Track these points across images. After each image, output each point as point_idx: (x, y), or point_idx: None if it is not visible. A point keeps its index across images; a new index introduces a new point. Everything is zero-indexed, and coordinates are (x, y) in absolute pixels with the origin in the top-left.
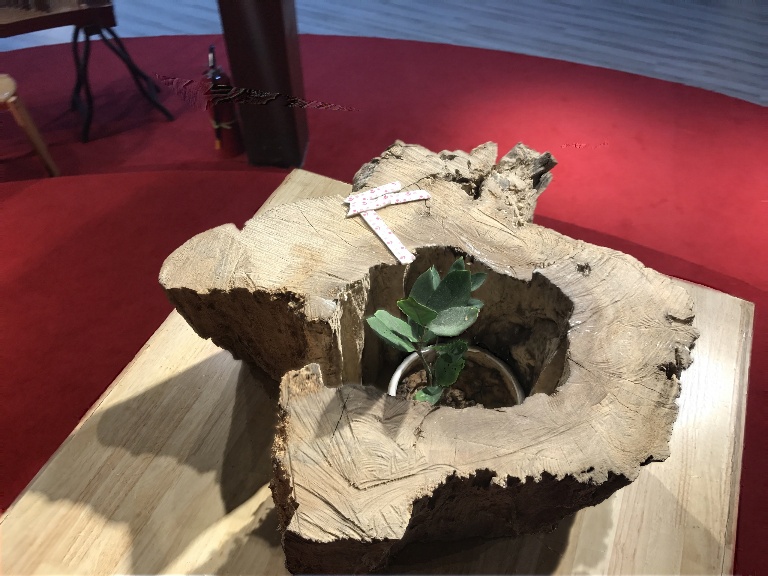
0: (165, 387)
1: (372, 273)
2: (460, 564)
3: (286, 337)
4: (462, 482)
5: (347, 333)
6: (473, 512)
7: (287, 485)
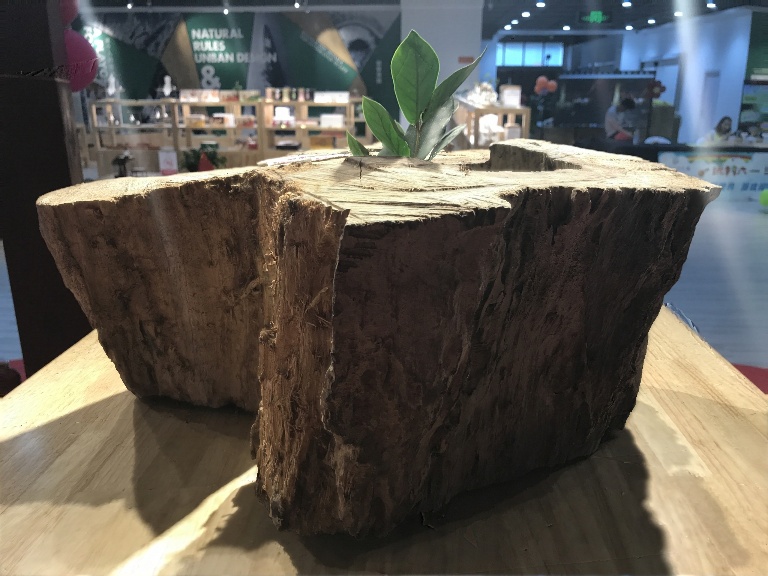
0: (15, 442)
1: None
2: (533, 500)
3: (219, 273)
4: (538, 207)
5: None
6: (532, 382)
7: (311, 245)
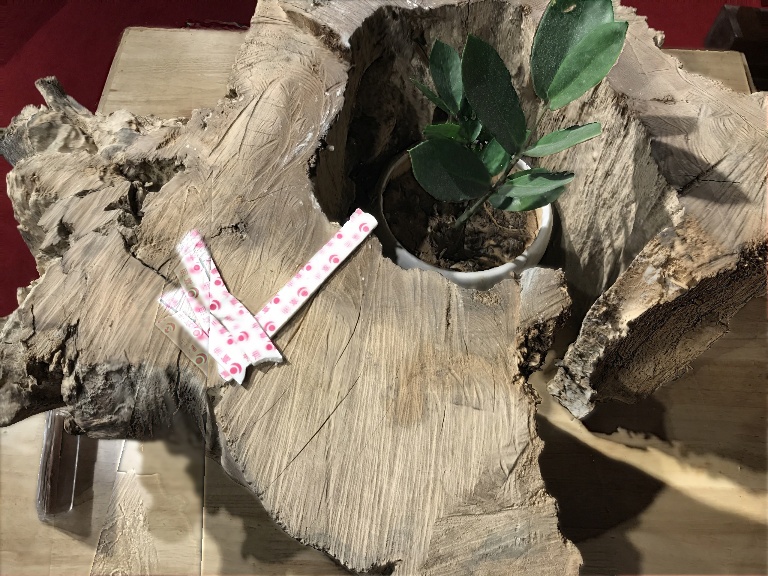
0: None
1: None
2: None
3: None
4: None
5: None
6: None
7: None
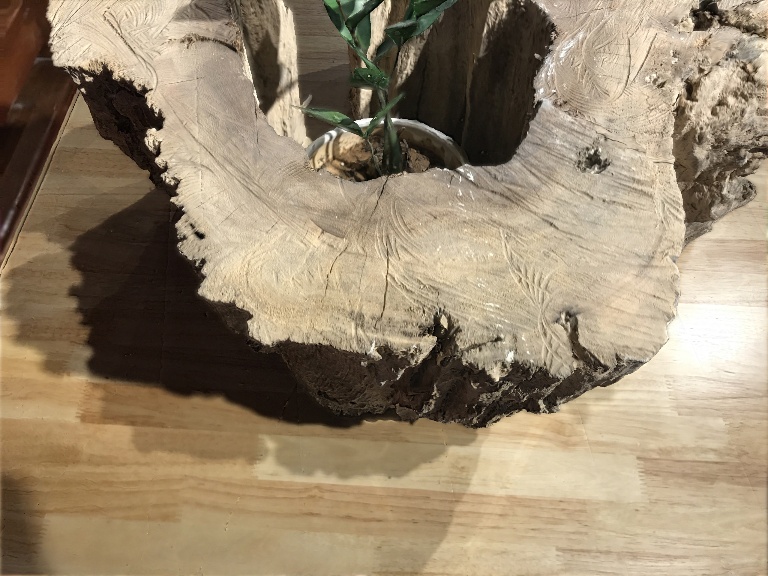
0: None
1: None
2: None
3: None
4: None
5: None
6: None
7: None
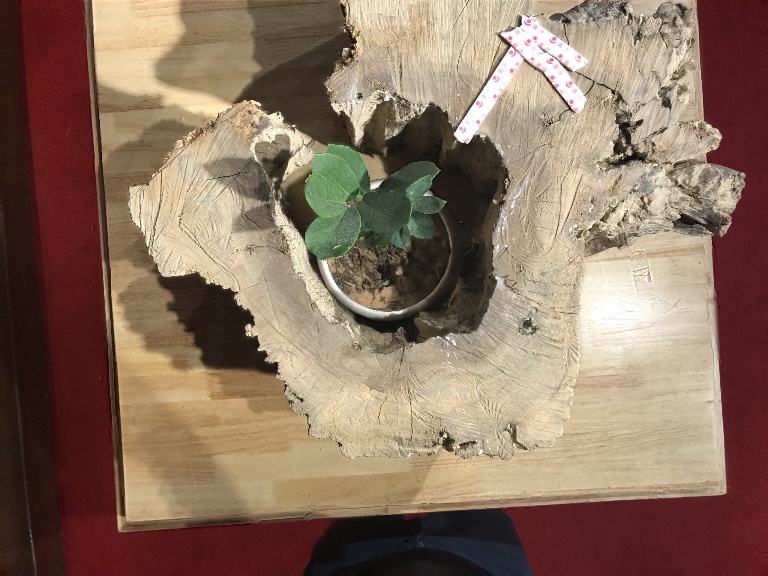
0: None
1: (434, 107)
2: None
3: None
4: None
5: (382, 116)
6: None
7: None
